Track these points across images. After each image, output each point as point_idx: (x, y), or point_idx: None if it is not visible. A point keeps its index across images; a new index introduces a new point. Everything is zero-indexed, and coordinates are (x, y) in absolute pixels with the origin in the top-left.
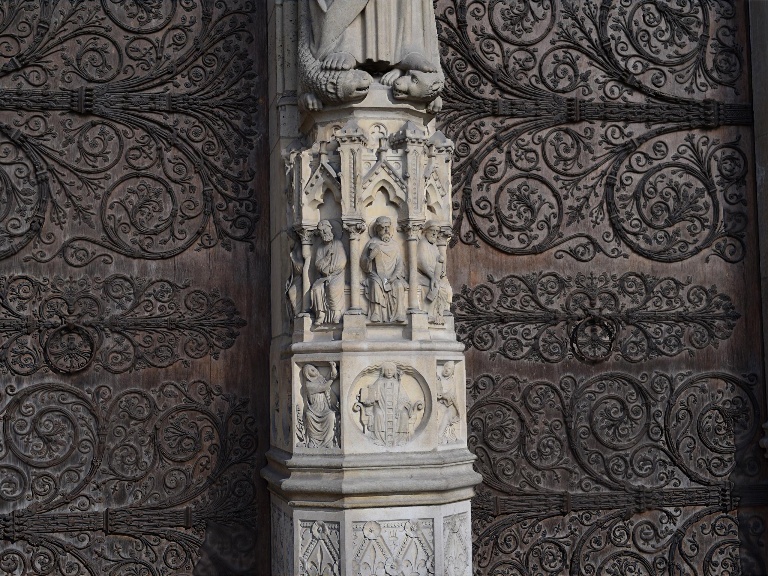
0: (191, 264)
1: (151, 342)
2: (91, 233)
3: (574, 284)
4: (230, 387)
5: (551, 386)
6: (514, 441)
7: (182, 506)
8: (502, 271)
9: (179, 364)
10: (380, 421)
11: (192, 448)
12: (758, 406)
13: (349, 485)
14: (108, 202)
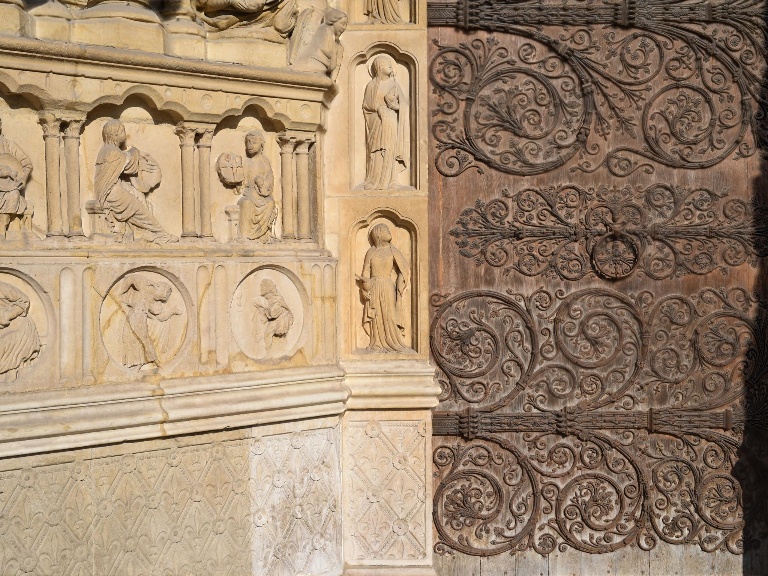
0: (729, 173)
1: (691, 250)
2: (633, 144)
3: None
4: (767, 294)
5: None
6: None
7: (721, 409)
8: None
9: (718, 271)
10: None
11: (730, 353)
12: None
13: None
14: (649, 113)
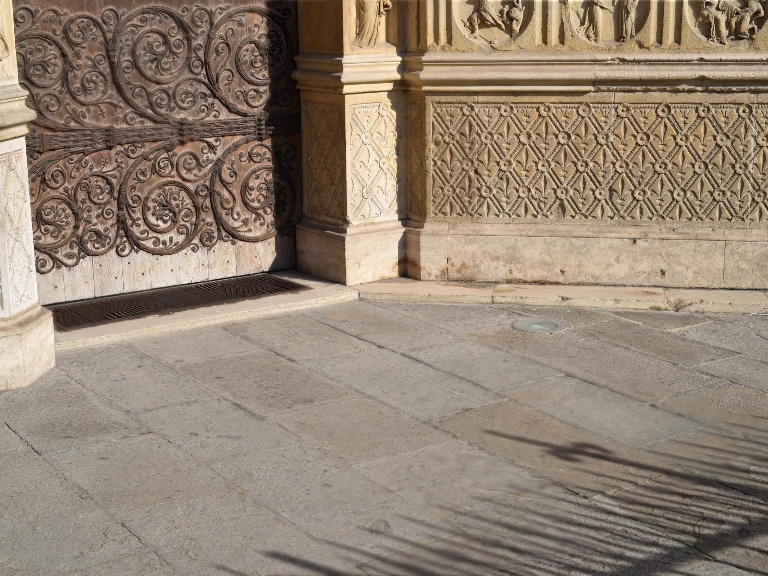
0: None
1: None
2: None
3: None
4: None
5: (93, 19)
6: (57, 76)
7: None
8: None
9: None
10: None
11: None
12: (291, 40)
13: None
14: None
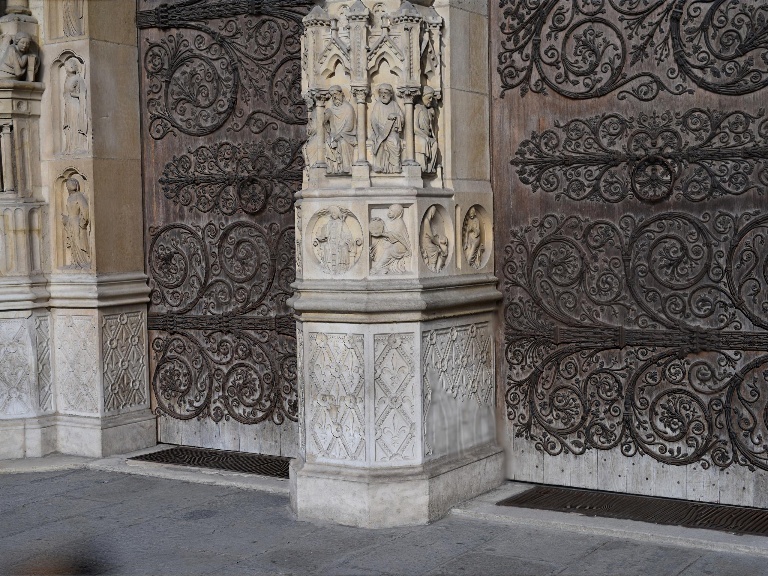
0: None
1: None
2: (265, 107)
3: (636, 124)
4: None
5: (610, 225)
6: (575, 276)
7: None
8: (568, 116)
9: None
10: (327, 254)
11: None
12: None
13: (299, 303)
14: (274, 82)
